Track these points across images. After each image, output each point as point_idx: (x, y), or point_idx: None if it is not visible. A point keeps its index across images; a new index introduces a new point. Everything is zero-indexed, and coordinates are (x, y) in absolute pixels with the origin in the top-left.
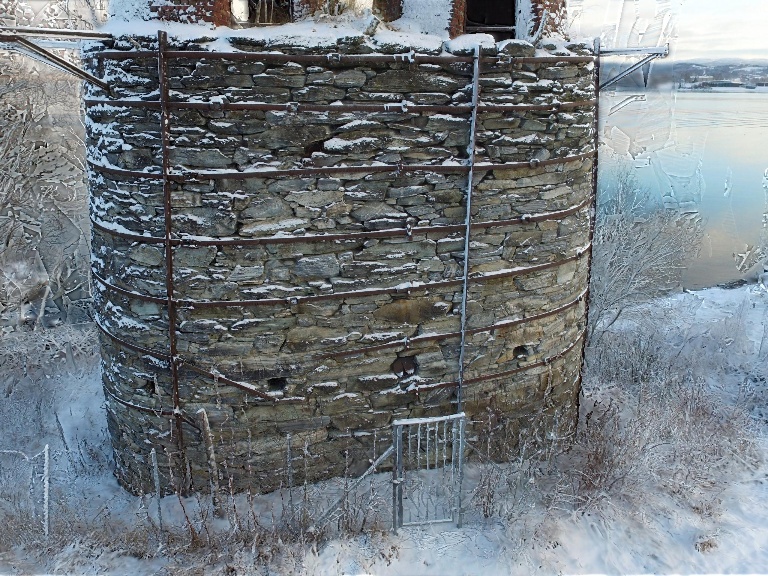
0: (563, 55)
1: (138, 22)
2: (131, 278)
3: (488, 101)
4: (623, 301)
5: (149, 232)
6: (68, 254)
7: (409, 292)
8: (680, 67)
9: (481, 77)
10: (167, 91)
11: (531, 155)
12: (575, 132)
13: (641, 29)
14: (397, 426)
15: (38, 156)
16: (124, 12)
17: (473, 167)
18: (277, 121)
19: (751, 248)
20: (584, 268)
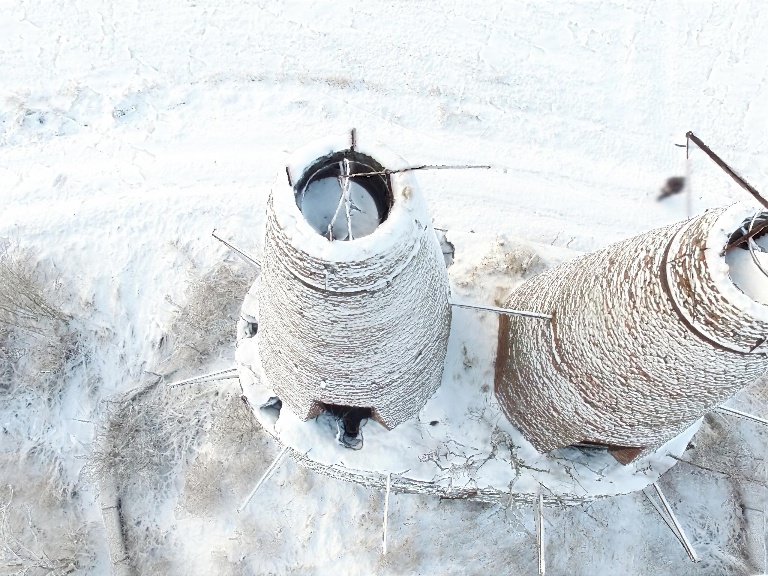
0: None
1: None
2: None
3: None
4: (4, 559)
5: None
6: None
7: None
8: None
9: None
10: None
11: None
12: None
13: None
14: None
15: None
16: None
17: None
18: None
19: None
20: None
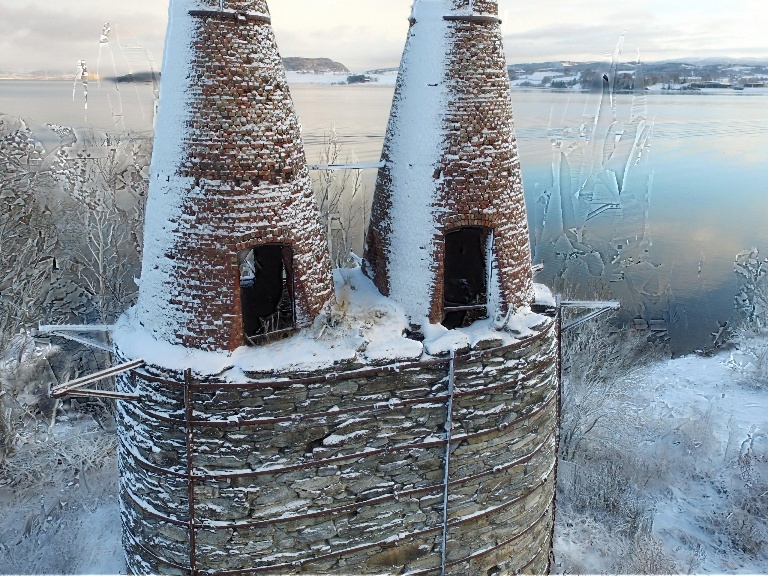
0: (527, 337)
1: (165, 344)
2: (159, 547)
3: (462, 387)
4: (598, 411)
5: (175, 516)
6: (76, 360)
7: (396, 543)
8: (656, 155)
9: (456, 369)
10: (191, 412)
11: (500, 420)
12: (539, 390)
13: (617, 130)
14: None
15: (47, 267)
16: (153, 331)
17: (450, 441)
18: (284, 430)
19: (724, 325)
20: (550, 480)
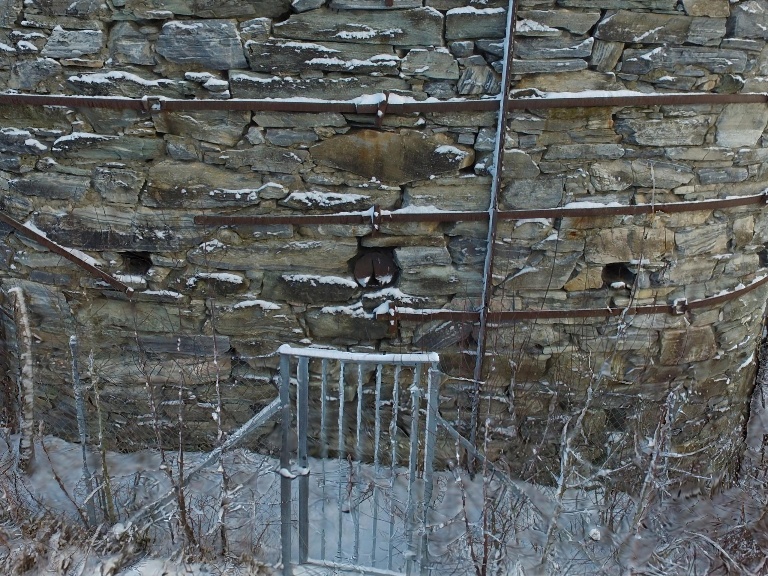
0: None
1: None
2: None
3: None
4: None
5: None
6: None
7: (379, 112)
8: None
9: None
10: None
11: None
12: None
13: None
14: (286, 357)
15: None
16: None
17: None
18: None
19: None
20: None
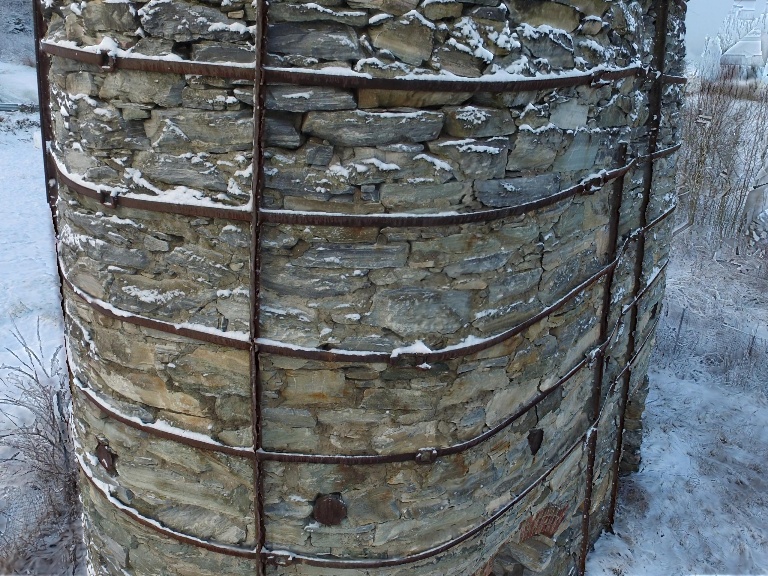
0: None
1: None
2: None
3: None
4: None
5: None
6: None
7: None
8: None
9: None
10: None
11: None
12: None
13: None
14: None
15: None
16: None
17: None
18: None
19: None
20: None
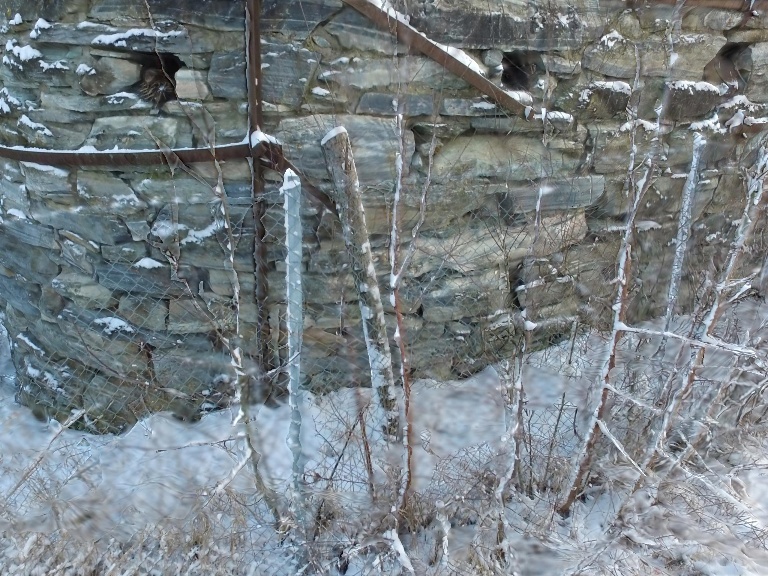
0: None
1: None
2: None
3: None
4: None
5: None
6: None
7: None
8: None
9: None
10: None
11: None
12: None
13: None
14: None
15: None
16: None
17: None
18: None
19: None
20: None
